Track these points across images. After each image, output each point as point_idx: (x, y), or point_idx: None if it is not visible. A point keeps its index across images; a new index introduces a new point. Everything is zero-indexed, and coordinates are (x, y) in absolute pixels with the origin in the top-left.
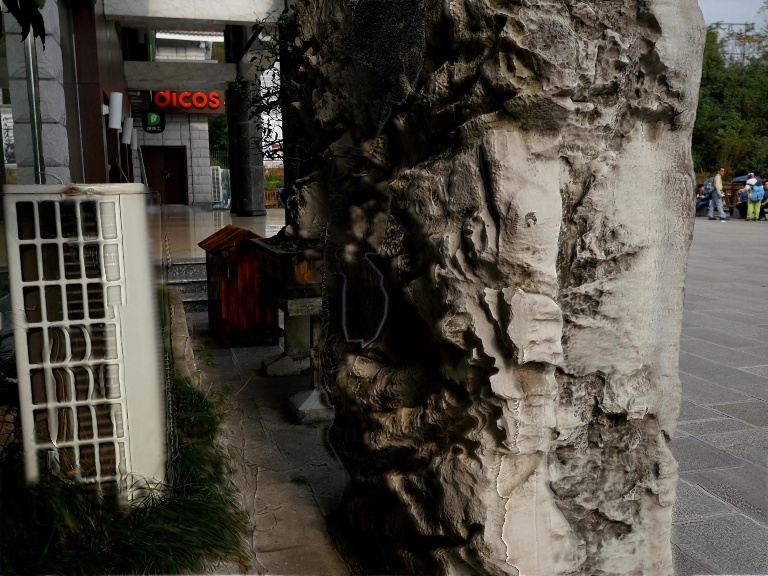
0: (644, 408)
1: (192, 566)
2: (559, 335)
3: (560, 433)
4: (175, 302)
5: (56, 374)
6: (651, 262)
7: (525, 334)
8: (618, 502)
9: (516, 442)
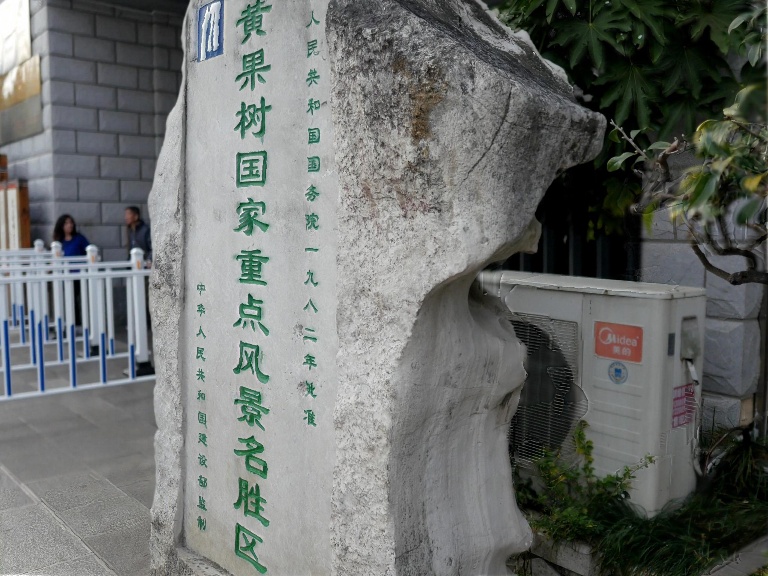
0: None
1: None
2: None
3: None
4: None
5: None
6: None
7: None
8: None
9: None
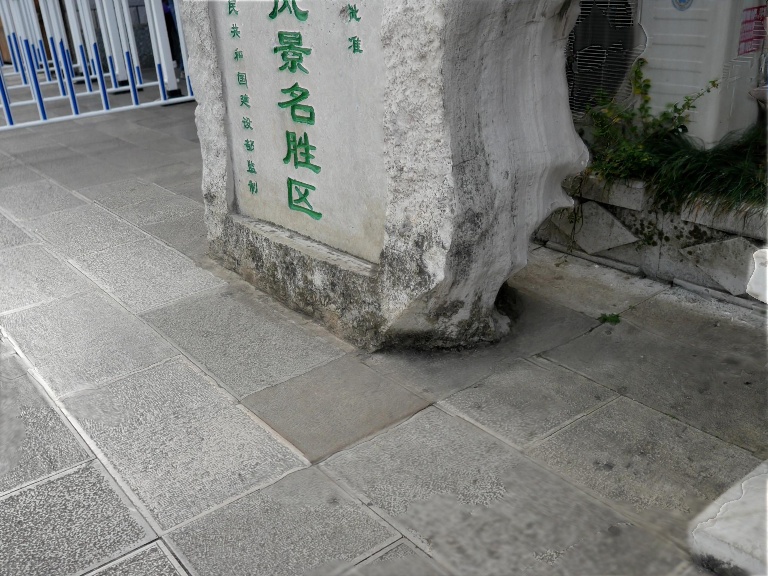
0: None
1: None
2: None
3: None
4: None
5: None
6: None
7: None
8: None
9: None
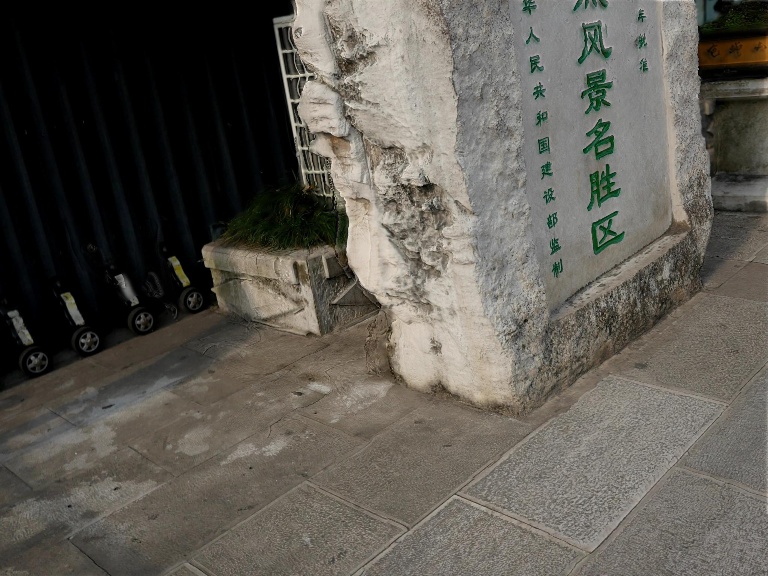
0: (414, 177)
1: (301, 243)
2: (335, 114)
3: (379, 189)
4: None
5: (301, 130)
6: (397, 58)
7: (306, 112)
8: (429, 251)
9: (337, 188)
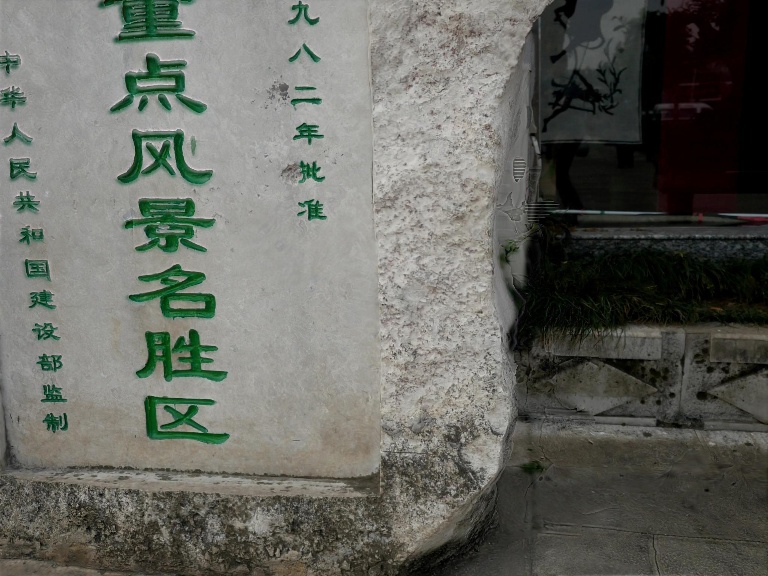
0: None
1: None
2: None
3: None
4: (569, 201)
5: None
6: None
7: None
8: None
9: None
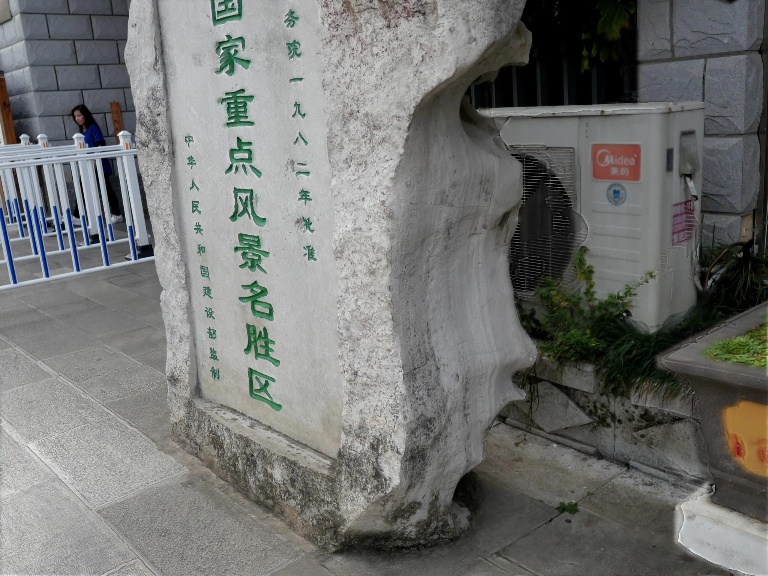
0: None
1: None
2: None
3: None
4: None
5: None
6: None
7: None
8: None
9: None
